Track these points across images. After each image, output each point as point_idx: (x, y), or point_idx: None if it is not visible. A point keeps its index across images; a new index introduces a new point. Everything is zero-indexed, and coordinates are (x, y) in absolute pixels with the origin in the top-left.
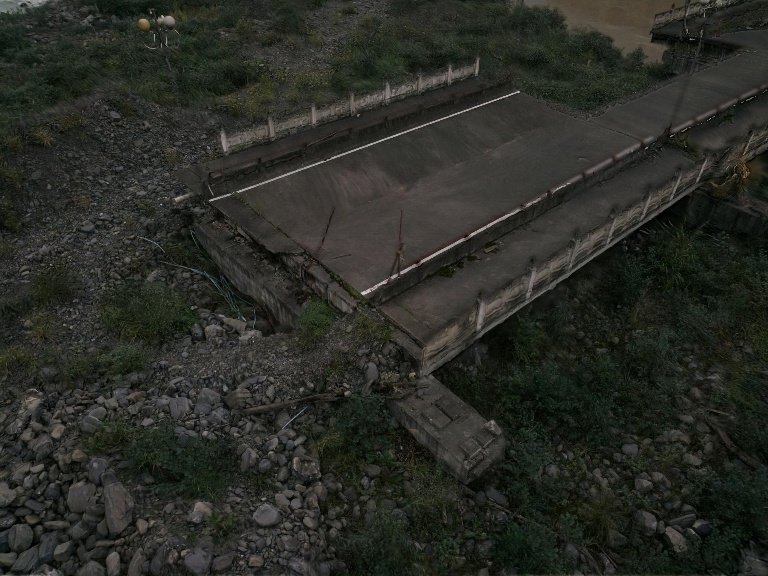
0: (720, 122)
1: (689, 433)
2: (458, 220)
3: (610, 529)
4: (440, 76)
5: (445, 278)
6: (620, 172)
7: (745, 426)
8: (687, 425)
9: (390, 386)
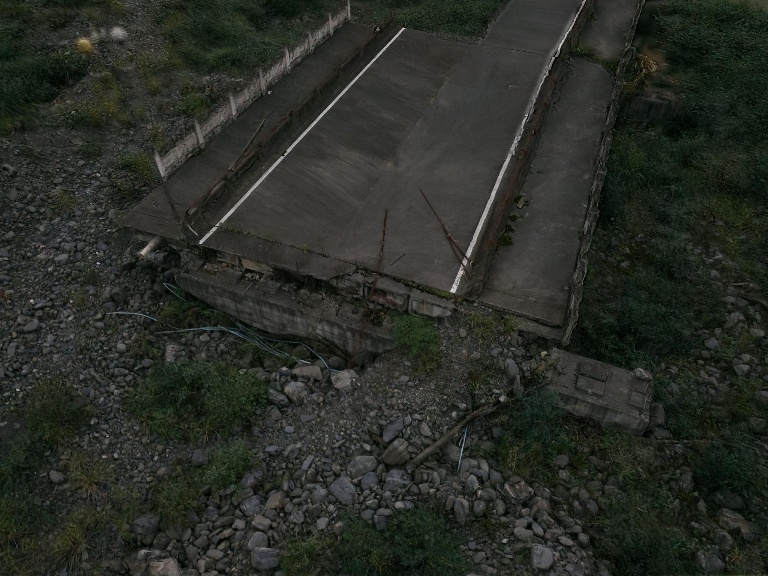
0: (590, 21)
1: (741, 311)
2: (468, 182)
3: (749, 418)
4: (323, 27)
5: (509, 247)
6: (560, 91)
7: (767, 288)
8: (733, 305)
9: (535, 374)
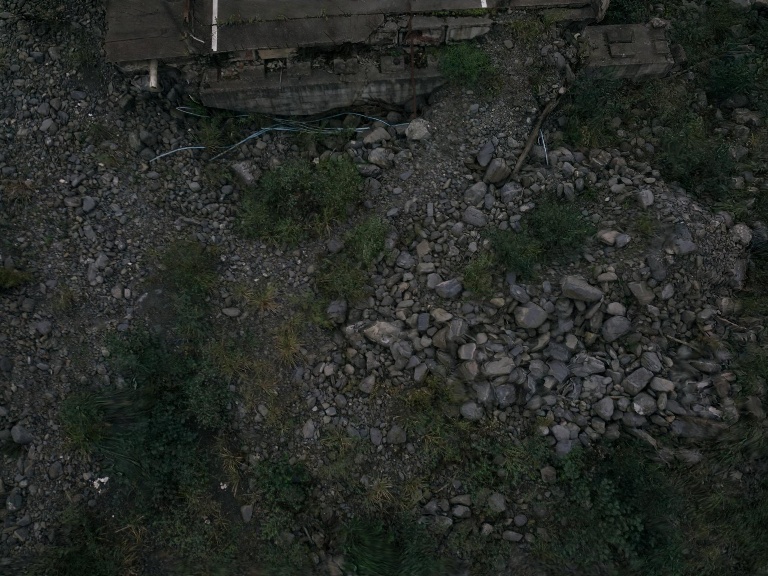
0: None
1: None
2: None
3: (730, 28)
4: None
5: None
6: None
7: None
8: None
9: (579, 58)
